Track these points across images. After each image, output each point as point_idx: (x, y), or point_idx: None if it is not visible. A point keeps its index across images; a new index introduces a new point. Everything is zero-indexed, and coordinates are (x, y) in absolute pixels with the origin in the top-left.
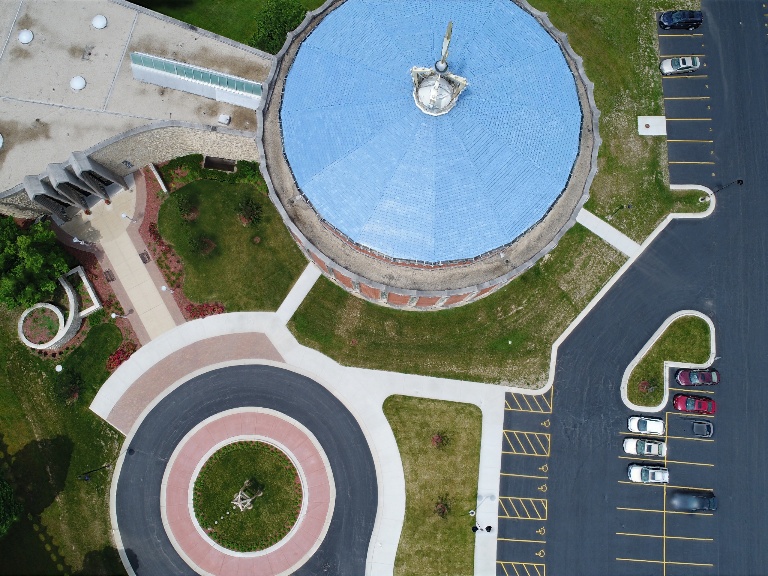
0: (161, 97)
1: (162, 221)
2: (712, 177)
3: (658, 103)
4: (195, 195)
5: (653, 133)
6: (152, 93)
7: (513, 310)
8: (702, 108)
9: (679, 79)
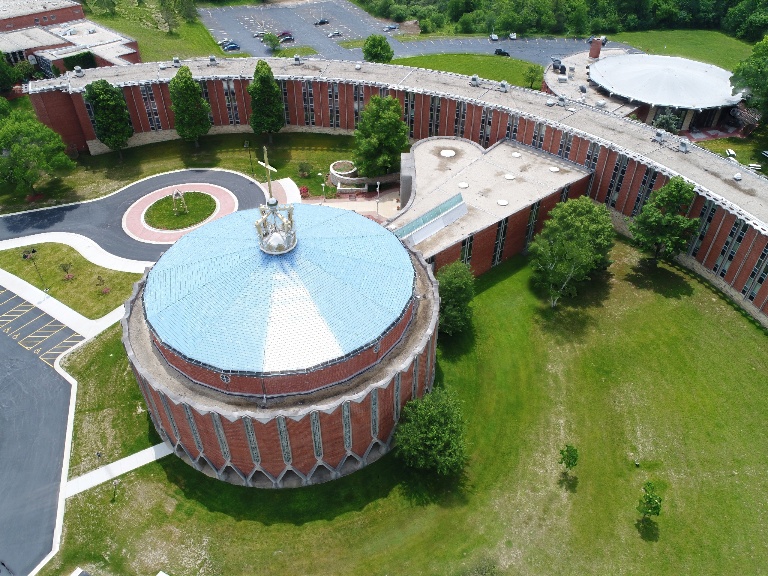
0: None
1: None
2: None
3: None
4: None
5: None
6: None
7: (129, 368)
8: None
9: None
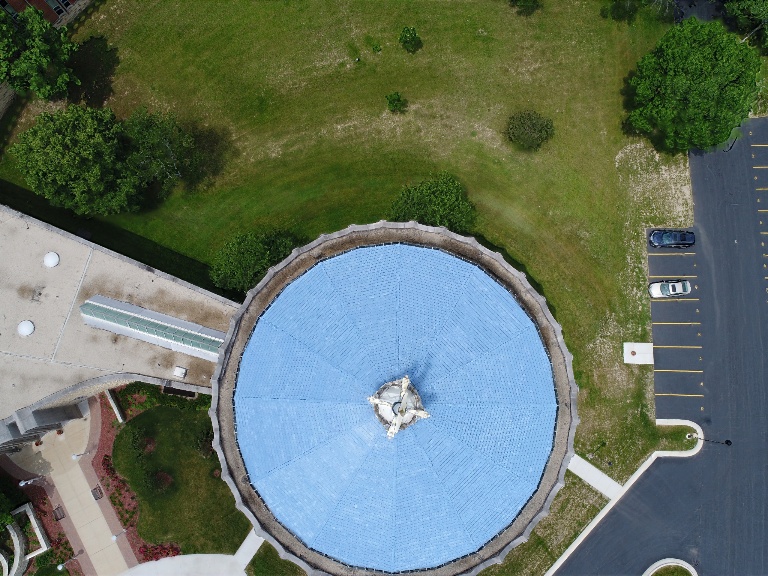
0: (114, 345)
1: (117, 453)
2: (701, 411)
3: (646, 328)
4: (153, 424)
5: (639, 362)
6: (104, 340)
7: None
8: (692, 335)
9: (669, 302)
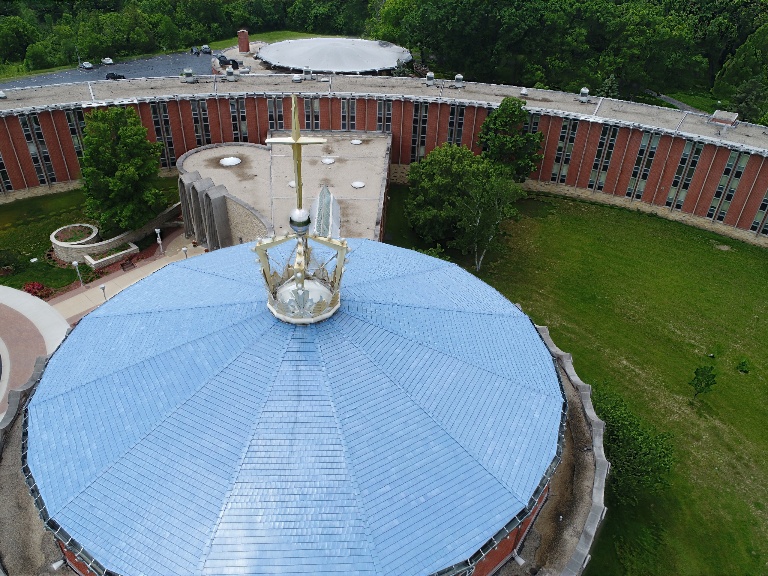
0: None
1: None
2: None
3: None
4: None
5: None
6: None
7: None
8: None
9: None
